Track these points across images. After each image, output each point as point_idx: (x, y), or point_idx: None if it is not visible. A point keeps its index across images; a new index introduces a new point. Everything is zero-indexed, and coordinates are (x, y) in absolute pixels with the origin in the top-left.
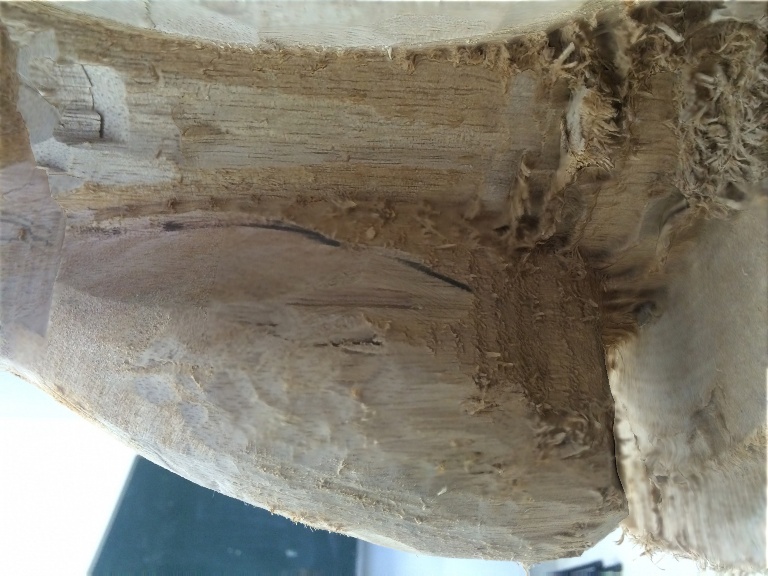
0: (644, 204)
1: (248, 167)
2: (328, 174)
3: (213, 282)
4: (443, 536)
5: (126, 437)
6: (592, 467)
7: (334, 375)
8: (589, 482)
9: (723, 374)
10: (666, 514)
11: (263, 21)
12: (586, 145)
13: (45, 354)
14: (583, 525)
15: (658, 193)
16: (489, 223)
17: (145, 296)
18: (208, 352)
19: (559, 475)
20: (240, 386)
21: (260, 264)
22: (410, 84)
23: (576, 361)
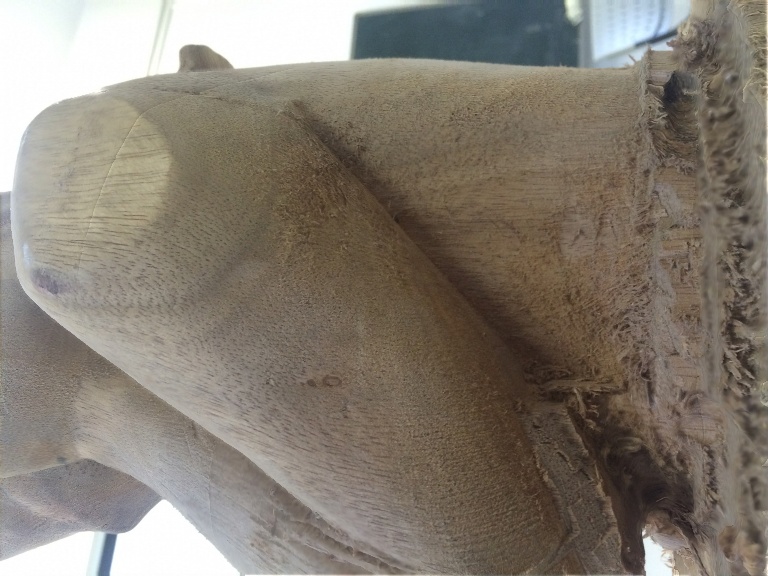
0: None
1: None
2: None
3: None
4: None
5: None
6: None
7: None
8: None
9: (680, 573)
10: None
11: None
12: None
13: None
14: None
15: None
16: None
17: None
18: None
19: None
20: None
21: None
22: None
23: None
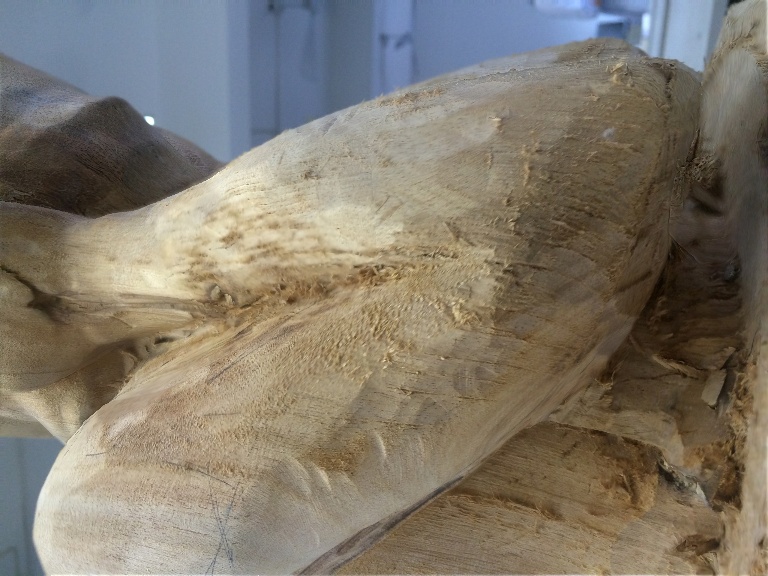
0: None
1: None
2: None
3: None
4: None
5: None
6: None
7: None
8: None
9: None
10: None
11: None
12: None
13: None
14: None
15: None
16: None
17: None
18: None
19: None
20: None
21: None
22: None
23: None
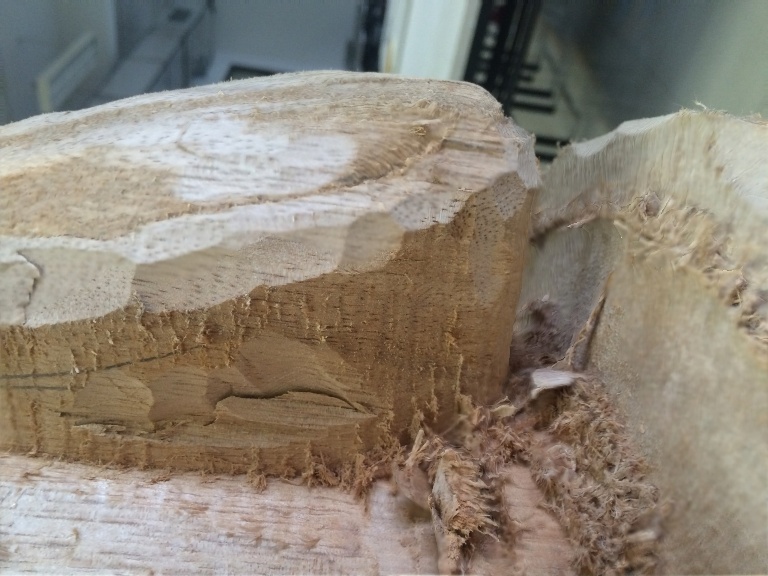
0: None
1: None
2: None
3: None
4: None
5: None
6: None
7: None
8: None
9: None
10: None
11: (143, 258)
12: (460, 504)
13: None
14: None
15: None
16: None
17: None
18: None
19: None
20: None
21: None
22: (260, 502)
23: None
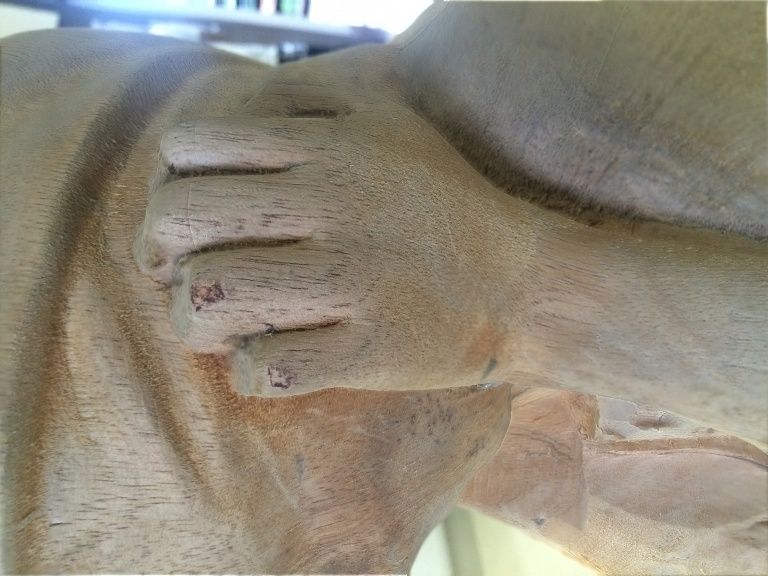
0: None
1: None
2: None
3: (706, 504)
4: None
5: None
6: None
7: None
8: None
9: None
10: None
11: None
12: None
13: (579, 539)
14: None
15: None
16: None
17: (666, 515)
18: (715, 557)
19: None
20: (730, 574)
21: (730, 487)
22: None
23: None
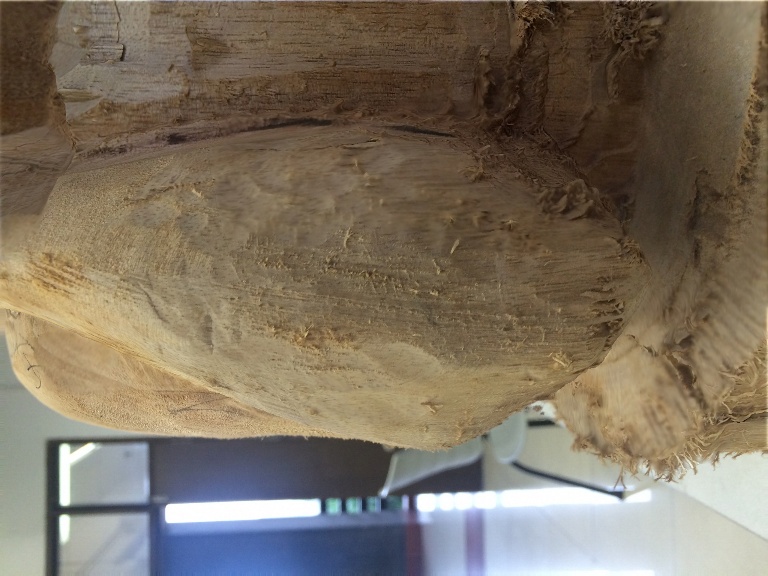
0: (588, 70)
1: (248, 76)
2: (318, 81)
3: None
4: (464, 318)
5: (114, 285)
6: (601, 225)
7: (335, 161)
8: (602, 234)
9: (698, 157)
10: (703, 376)
11: None
12: None
13: (38, 229)
14: (608, 279)
15: (597, 58)
16: (462, 117)
17: (149, 158)
18: (210, 169)
19: (570, 229)
20: (242, 189)
21: None
22: None
23: (563, 177)
